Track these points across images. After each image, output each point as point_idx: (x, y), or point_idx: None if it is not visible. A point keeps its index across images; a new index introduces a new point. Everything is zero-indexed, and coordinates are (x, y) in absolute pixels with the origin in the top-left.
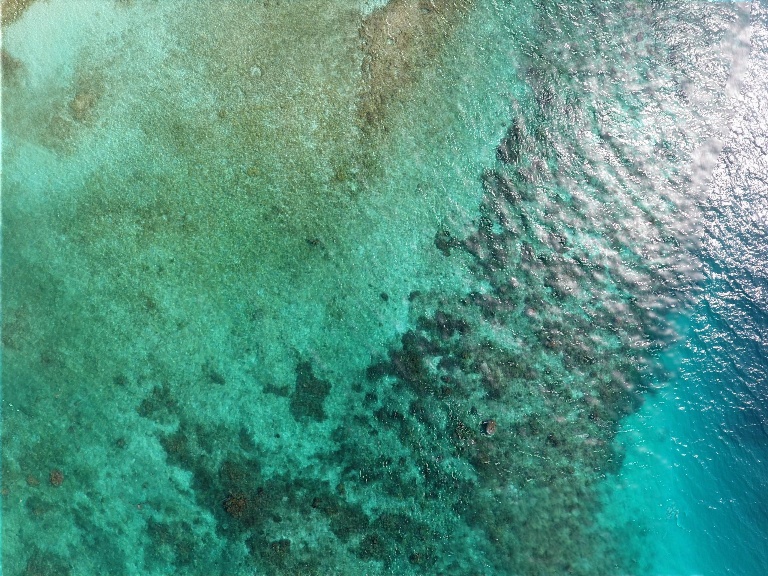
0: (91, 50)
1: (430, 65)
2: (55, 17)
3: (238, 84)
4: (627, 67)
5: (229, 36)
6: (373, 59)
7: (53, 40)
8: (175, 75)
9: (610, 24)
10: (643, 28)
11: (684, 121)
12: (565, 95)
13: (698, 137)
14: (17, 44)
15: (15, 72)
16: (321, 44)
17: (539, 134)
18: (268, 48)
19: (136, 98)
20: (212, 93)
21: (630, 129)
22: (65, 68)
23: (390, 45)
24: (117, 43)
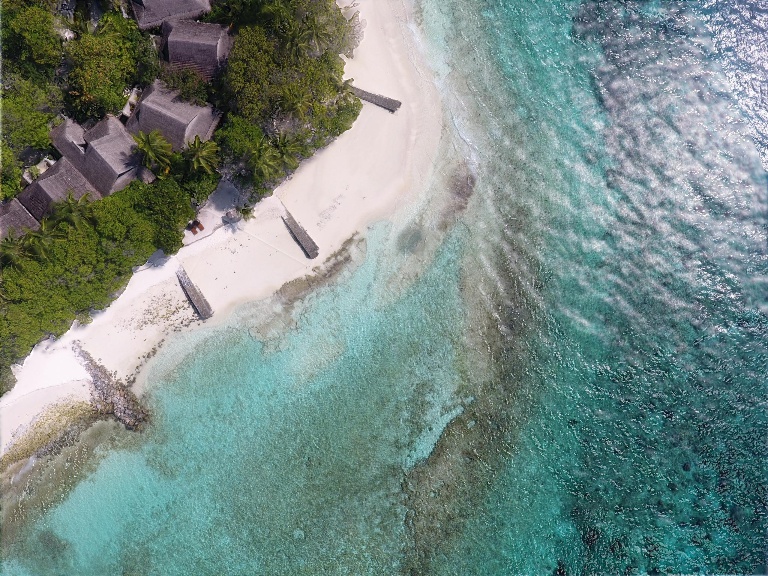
0: (136, 525)
1: (473, 514)
2: (101, 495)
3: (282, 548)
4: (674, 498)
5: (272, 500)
6: (416, 514)
7: (99, 518)
8: (219, 544)
9: (656, 456)
10: (690, 457)
11: (734, 550)
12: (611, 532)
13: (748, 566)
14: (64, 525)
15: (63, 554)
16: (364, 501)
17: (585, 575)
18: (311, 509)
19: (181, 570)
20: (256, 559)
21: (678, 563)
22: (111, 545)
23: (433, 498)
24: (162, 516)
